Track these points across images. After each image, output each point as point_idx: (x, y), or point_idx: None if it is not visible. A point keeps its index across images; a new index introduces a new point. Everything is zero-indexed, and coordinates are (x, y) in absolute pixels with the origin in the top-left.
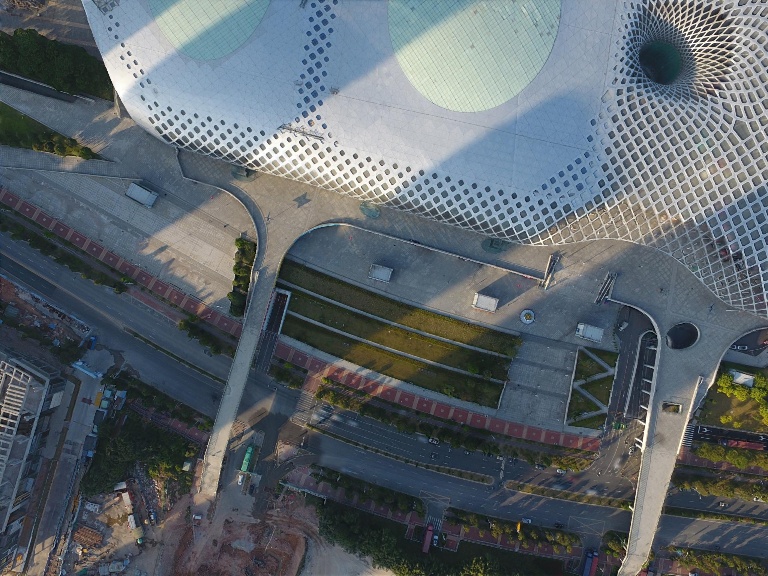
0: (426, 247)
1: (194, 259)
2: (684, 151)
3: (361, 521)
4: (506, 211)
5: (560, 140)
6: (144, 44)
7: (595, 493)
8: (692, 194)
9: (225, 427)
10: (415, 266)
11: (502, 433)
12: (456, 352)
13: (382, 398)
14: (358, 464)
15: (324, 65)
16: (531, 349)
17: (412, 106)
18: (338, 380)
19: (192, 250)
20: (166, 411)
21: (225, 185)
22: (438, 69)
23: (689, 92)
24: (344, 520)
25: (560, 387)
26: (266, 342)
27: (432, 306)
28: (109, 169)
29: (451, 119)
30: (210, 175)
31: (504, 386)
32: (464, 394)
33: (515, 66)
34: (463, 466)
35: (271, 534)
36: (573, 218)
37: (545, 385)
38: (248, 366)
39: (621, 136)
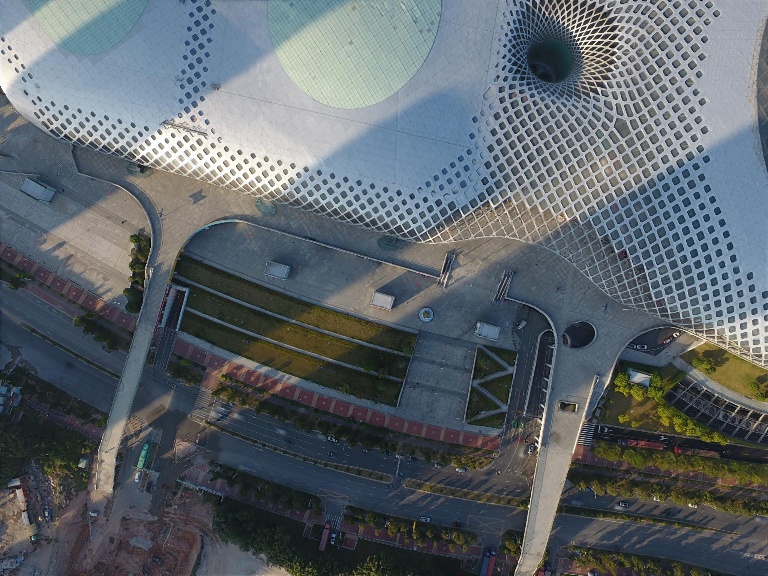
0: (322, 244)
1: (92, 255)
2: (566, 149)
3: (257, 519)
4: (392, 208)
5: (442, 137)
6: (24, 38)
7: (495, 492)
8: (575, 192)
9: (118, 424)
10: (314, 263)
11: (401, 431)
12: (355, 350)
13: (281, 396)
14: (256, 462)
15: (205, 61)
16: (430, 347)
17: (293, 102)
18: (237, 377)
19: (90, 246)
20: (63, 407)
21: (120, 181)
22: (317, 65)
23: (573, 90)
24: (237, 518)
25: (459, 385)
26: (165, 339)
27: (331, 304)
28: (7, 164)
29: (332, 115)
30: (105, 171)
31: (403, 384)
32: (358, 392)
33: (394, 63)
34: (362, 464)
35: (168, 531)
36: (459, 216)
37: (444, 383)
38: (142, 363)
39: (503, 134)
